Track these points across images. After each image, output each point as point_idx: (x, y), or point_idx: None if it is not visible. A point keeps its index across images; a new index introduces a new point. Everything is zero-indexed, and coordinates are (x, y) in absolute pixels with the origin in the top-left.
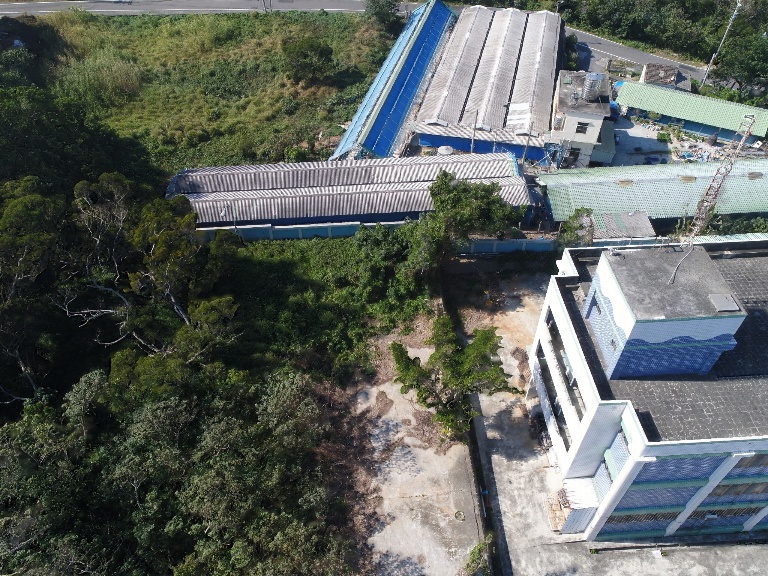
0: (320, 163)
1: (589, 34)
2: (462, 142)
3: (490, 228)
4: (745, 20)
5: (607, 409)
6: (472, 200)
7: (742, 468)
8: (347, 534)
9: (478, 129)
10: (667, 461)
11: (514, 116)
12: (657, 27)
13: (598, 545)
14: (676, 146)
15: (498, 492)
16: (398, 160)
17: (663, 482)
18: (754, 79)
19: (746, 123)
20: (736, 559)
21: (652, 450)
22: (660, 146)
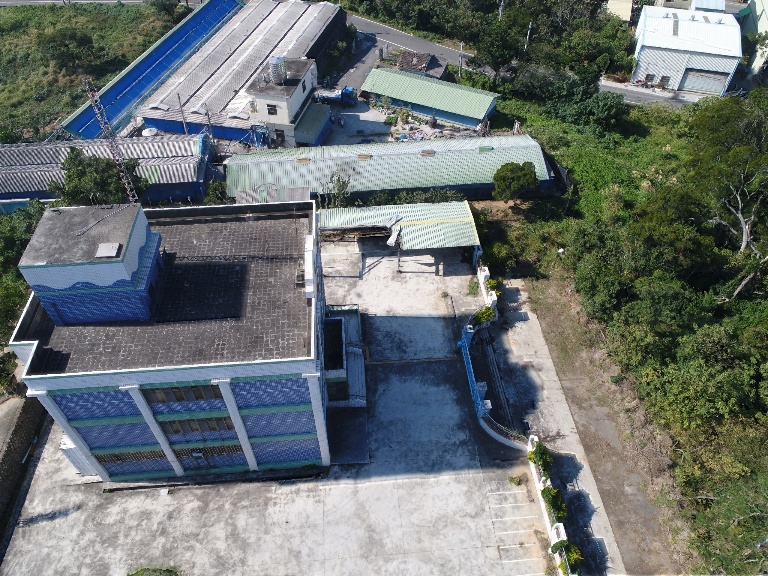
0: (18, 144)
1: (382, 25)
2: (182, 125)
3: (112, 200)
4: (527, 11)
5: (23, 350)
6: (93, 174)
7: (165, 404)
8: None
9: (195, 113)
10: (77, 396)
11: (236, 100)
12: (443, 18)
13: (113, 485)
14: (398, 129)
15: (47, 441)
16: (93, 141)
17: (101, 418)
18: (504, 66)
19: (469, 107)
20: (233, 495)
21: (35, 384)
22: (383, 129)
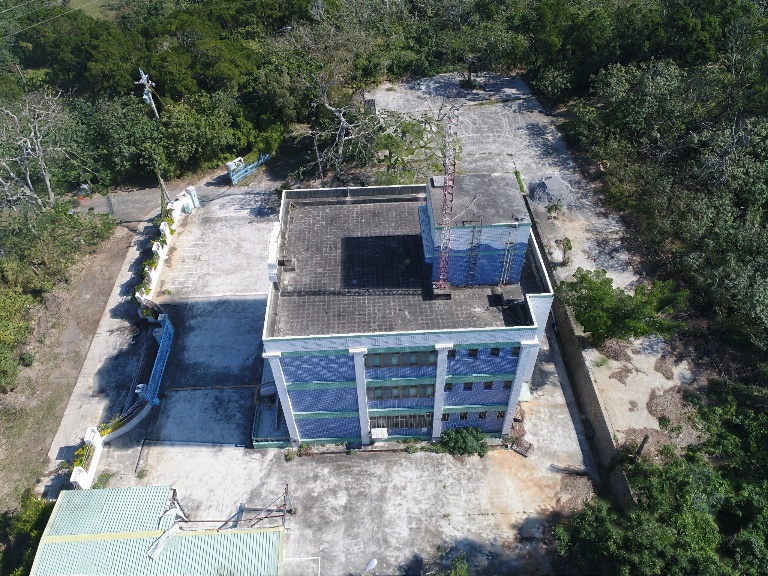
0: None
1: None
2: None
3: None
4: None
5: None
6: None
7: None
8: (656, 278)
9: None
10: None
11: None
12: None
13: None
14: None
15: None
16: None
17: None
18: None
19: None
20: None
21: None
22: None
